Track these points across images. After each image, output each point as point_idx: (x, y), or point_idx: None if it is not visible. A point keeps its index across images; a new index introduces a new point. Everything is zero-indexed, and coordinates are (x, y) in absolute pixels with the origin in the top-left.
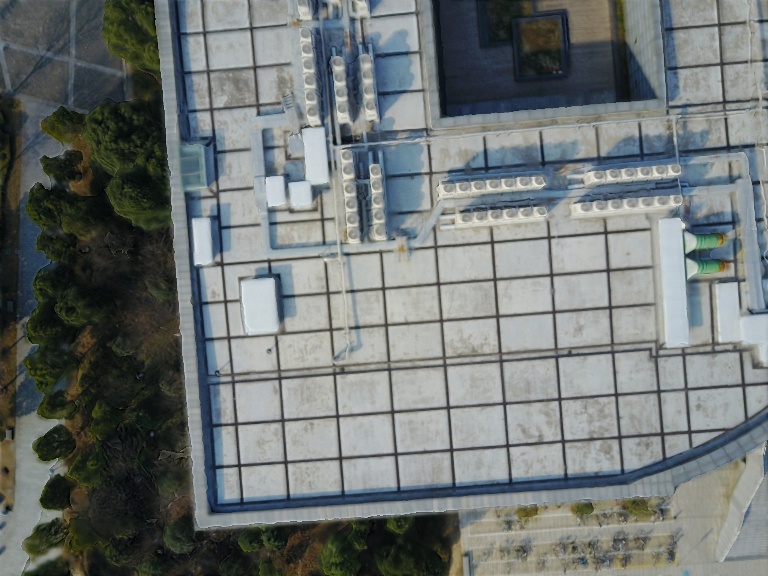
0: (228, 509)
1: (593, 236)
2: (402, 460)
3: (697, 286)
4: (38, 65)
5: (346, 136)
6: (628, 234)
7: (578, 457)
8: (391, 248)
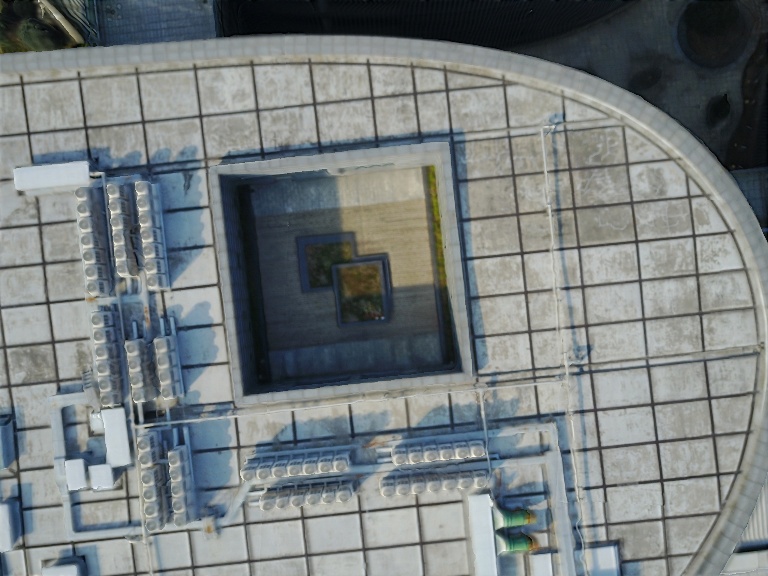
0: None
1: (404, 509)
2: None
3: (511, 556)
4: None
5: (150, 411)
6: (440, 507)
7: None
8: (198, 528)
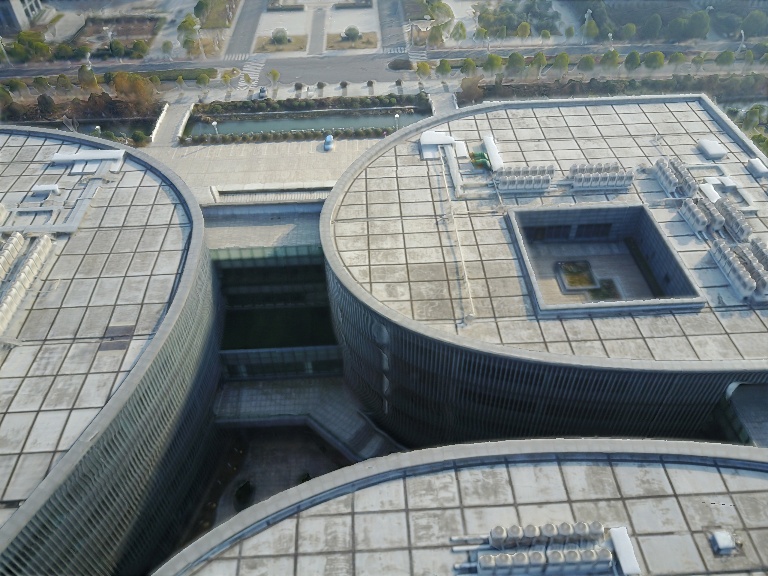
0: (692, 100)
1: None
2: (614, 112)
3: None
4: None
5: None
6: None
7: (528, 113)
8: None
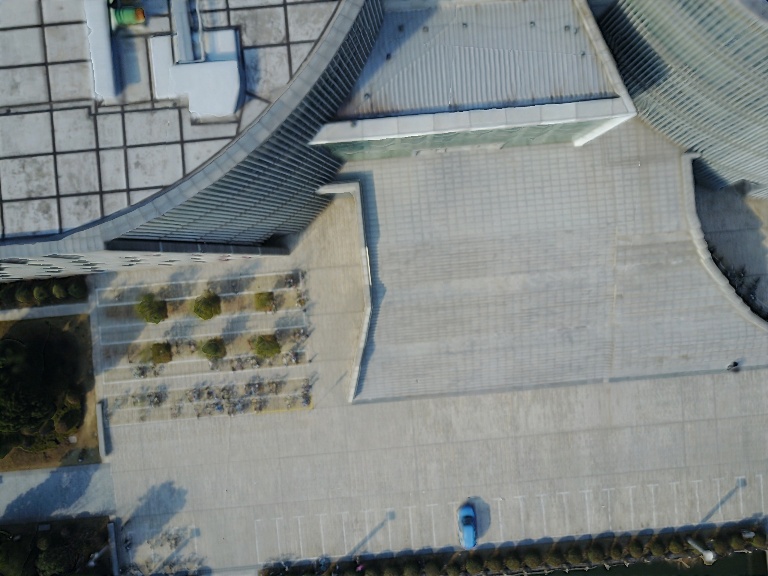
0: None
1: None
2: None
3: (134, 41)
4: None
5: None
6: None
7: (16, 217)
8: None
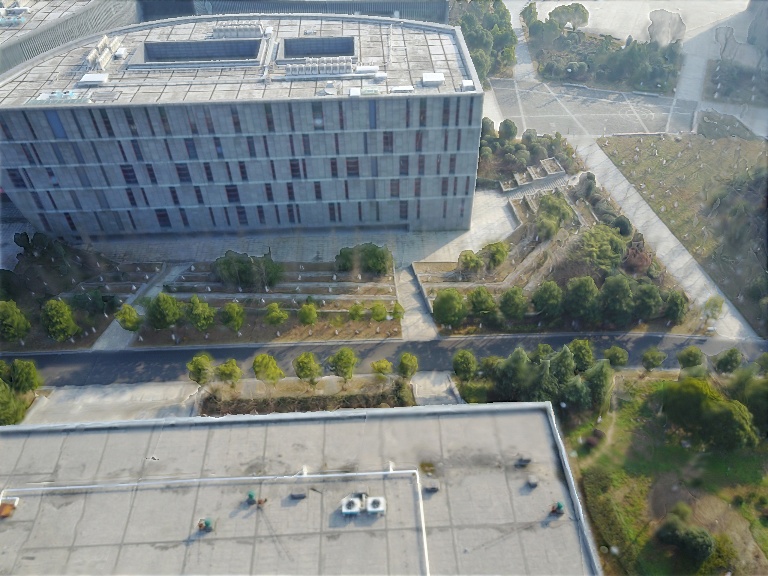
0: None
1: None
2: None
3: None
4: (532, 88)
5: None
6: None
7: None
8: None
